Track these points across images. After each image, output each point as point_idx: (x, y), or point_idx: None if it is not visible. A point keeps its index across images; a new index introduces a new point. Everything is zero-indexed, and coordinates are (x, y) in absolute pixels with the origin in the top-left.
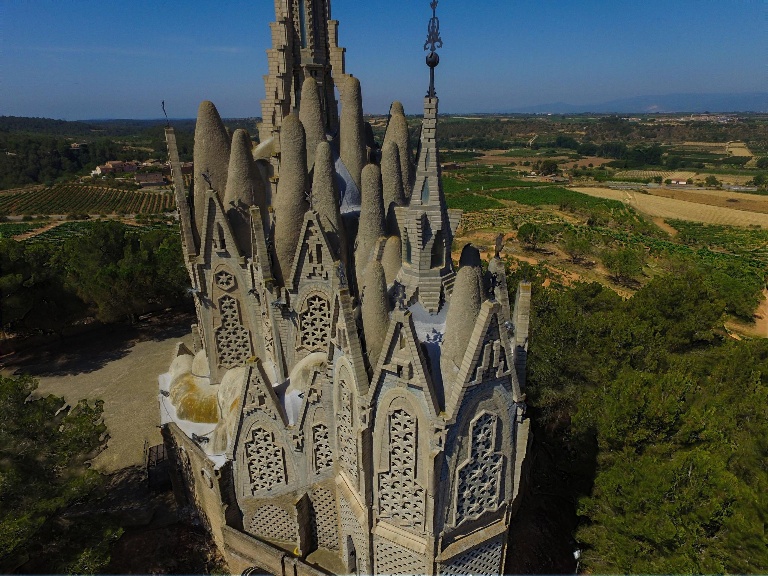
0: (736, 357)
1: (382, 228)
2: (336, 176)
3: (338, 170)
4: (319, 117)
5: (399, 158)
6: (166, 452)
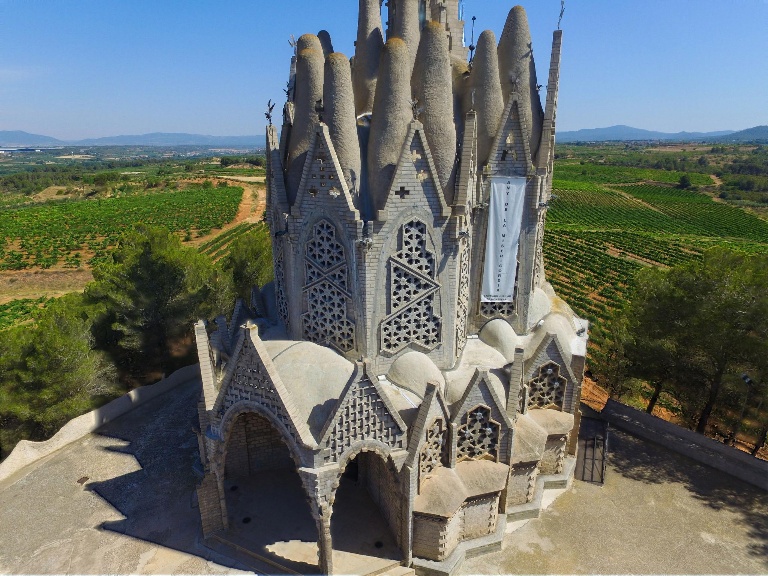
0: None
1: None
2: None
3: None
4: None
5: None
6: (582, 454)
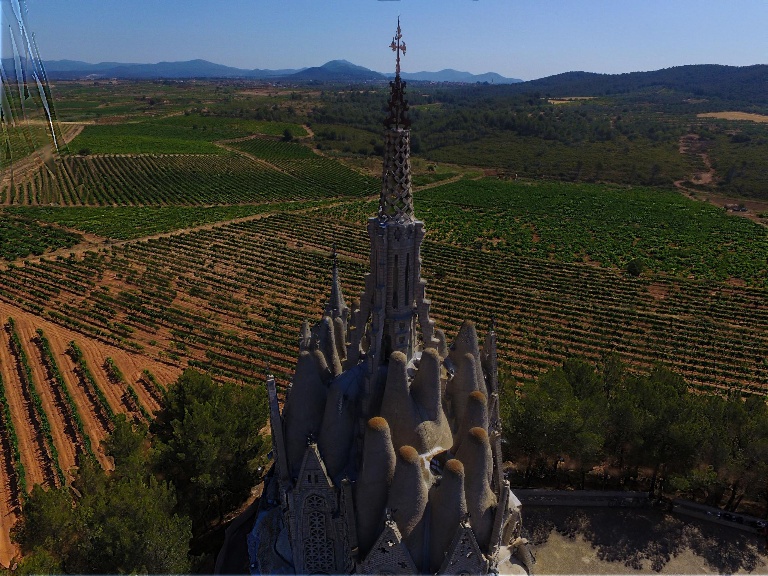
0: (40, 495)
1: None
2: None
3: None
4: None
5: None
6: None
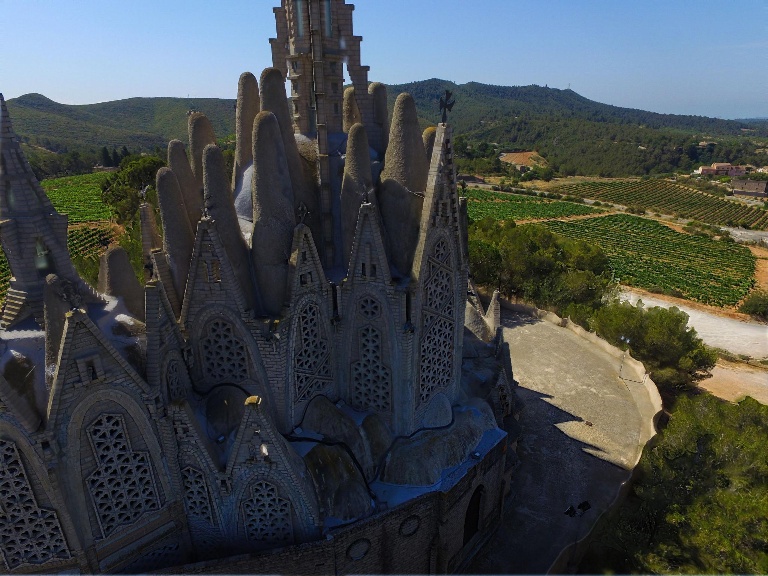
0: None
1: (168, 240)
2: (183, 177)
3: (245, 174)
4: (239, 115)
5: (212, 167)
6: None
